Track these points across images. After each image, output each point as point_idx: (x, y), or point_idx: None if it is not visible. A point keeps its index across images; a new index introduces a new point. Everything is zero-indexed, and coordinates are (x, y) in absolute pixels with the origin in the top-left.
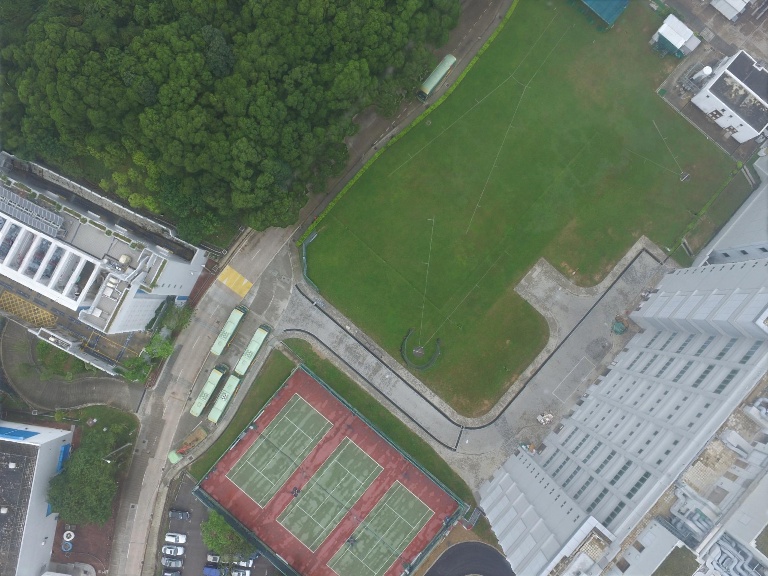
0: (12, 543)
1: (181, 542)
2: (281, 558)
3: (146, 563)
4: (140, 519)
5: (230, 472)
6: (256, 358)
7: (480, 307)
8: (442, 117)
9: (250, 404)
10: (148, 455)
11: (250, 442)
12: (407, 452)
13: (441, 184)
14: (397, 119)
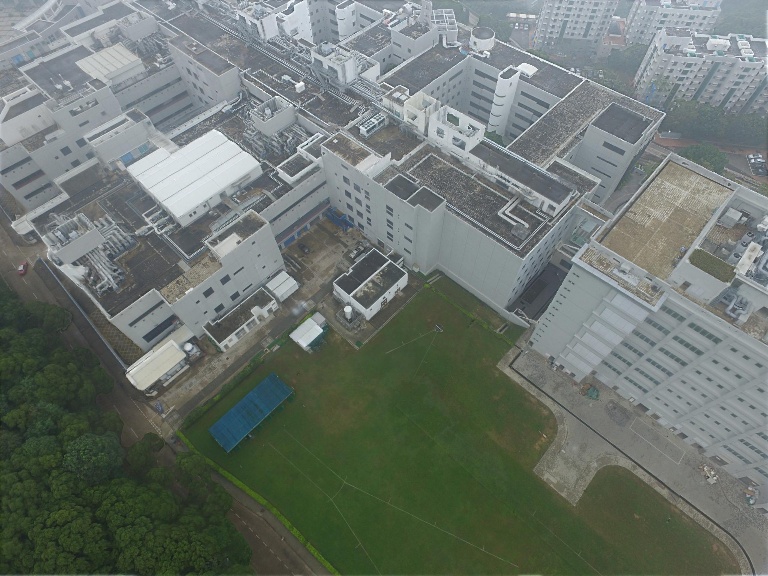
0: None
1: None
2: None
3: None
4: None
5: None
6: None
7: (604, 551)
8: None
9: None
10: None
11: None
12: None
13: None
14: None
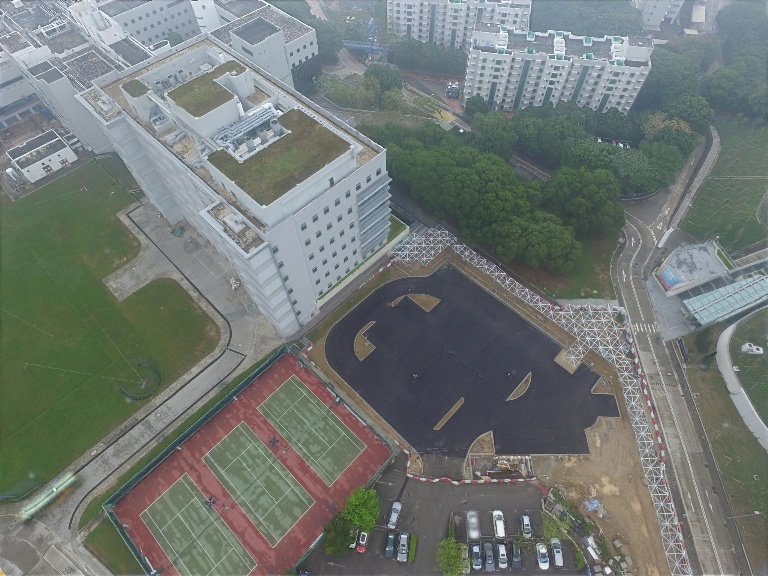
0: None
1: None
2: None
3: None
4: None
5: None
6: (85, 567)
7: (124, 328)
8: None
9: None
10: None
11: None
12: None
13: None
14: None
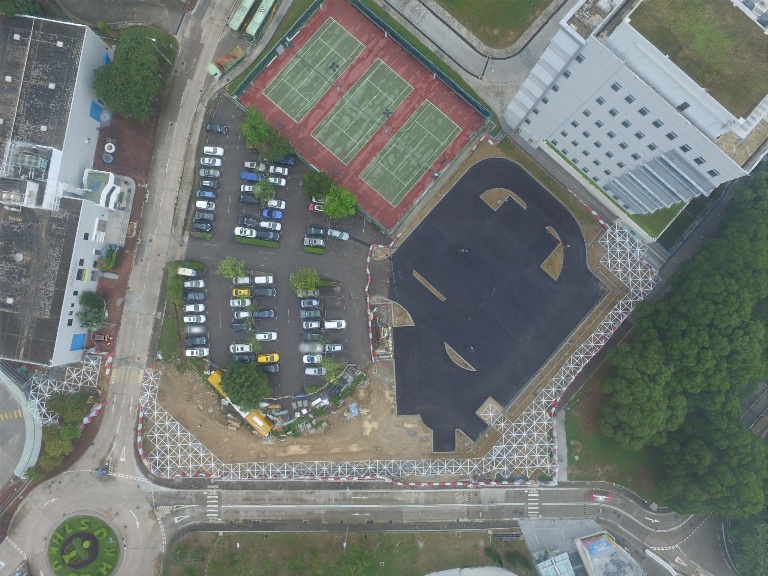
0: (59, 119)
1: (219, 154)
2: (315, 168)
3: (184, 178)
4: (179, 137)
5: (266, 89)
6: None
7: None
8: None
9: (286, 27)
10: (187, 76)
11: (286, 61)
12: None
13: None
14: None
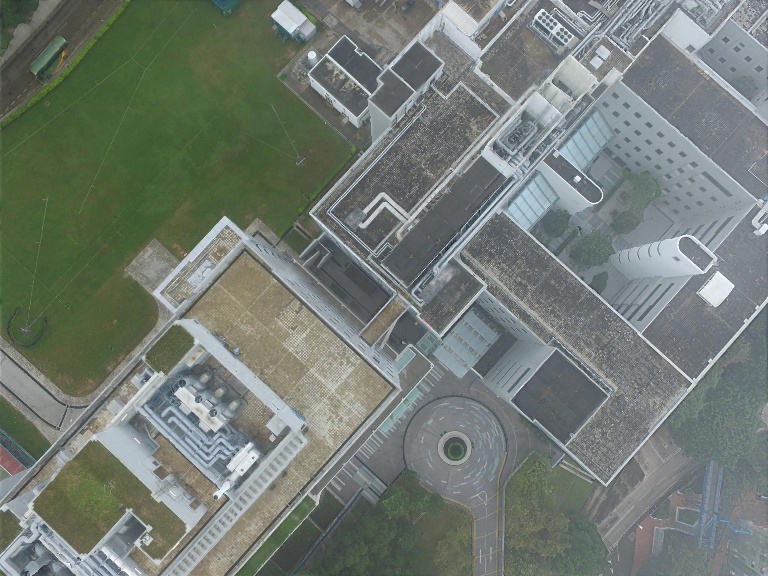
0: None
1: None
2: None
3: None
4: None
5: None
6: None
7: (89, 287)
8: (60, 98)
9: None
10: None
11: None
12: (4, 429)
13: (57, 164)
14: (17, 99)
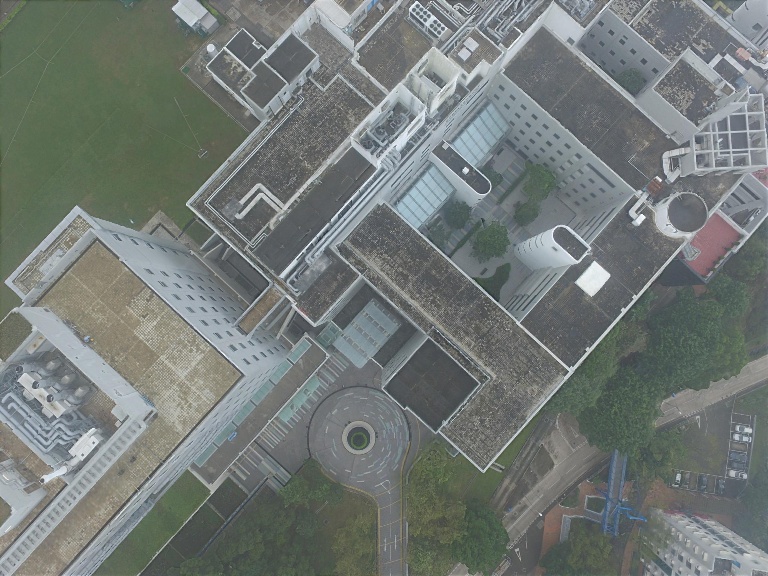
0: None
1: None
2: None
3: None
4: None
5: None
6: None
7: None
8: None
9: None
10: None
11: None
12: None
13: None
14: None
